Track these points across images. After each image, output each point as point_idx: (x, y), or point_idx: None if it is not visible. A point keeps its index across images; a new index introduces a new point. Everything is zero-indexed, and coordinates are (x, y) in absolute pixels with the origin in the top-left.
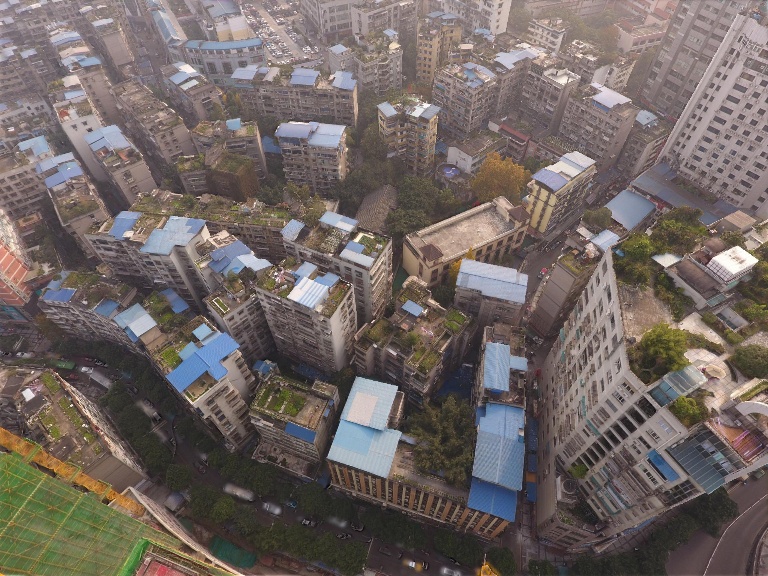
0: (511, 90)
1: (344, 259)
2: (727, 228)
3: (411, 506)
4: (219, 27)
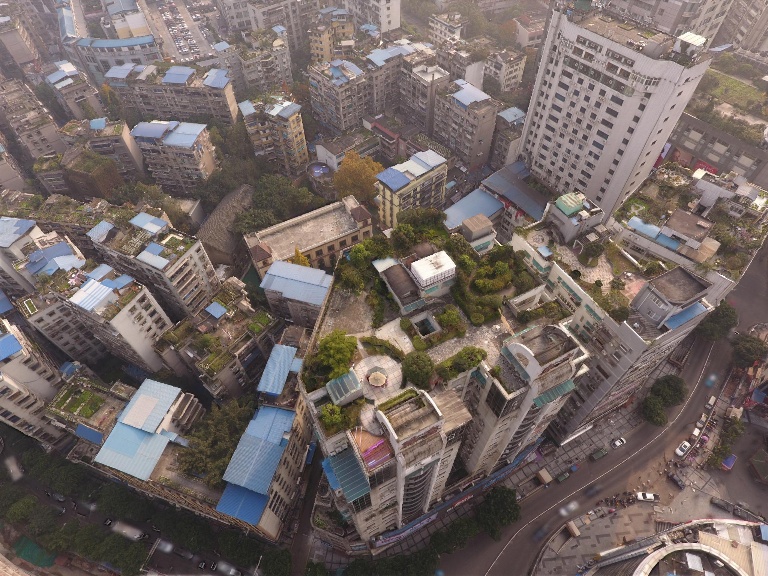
0: (391, 87)
1: (142, 261)
2: (466, 231)
3: None
4: (118, 24)
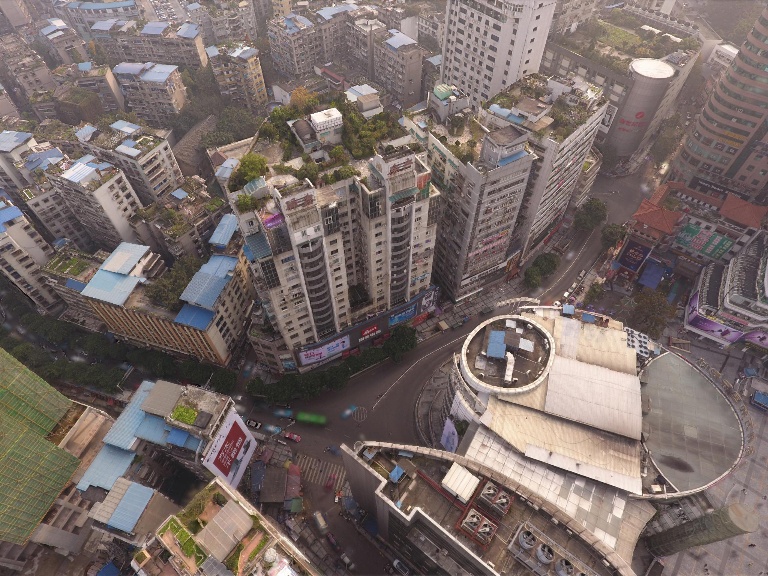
0: (339, 41)
1: (119, 152)
2: (360, 105)
3: (161, 341)
4: None
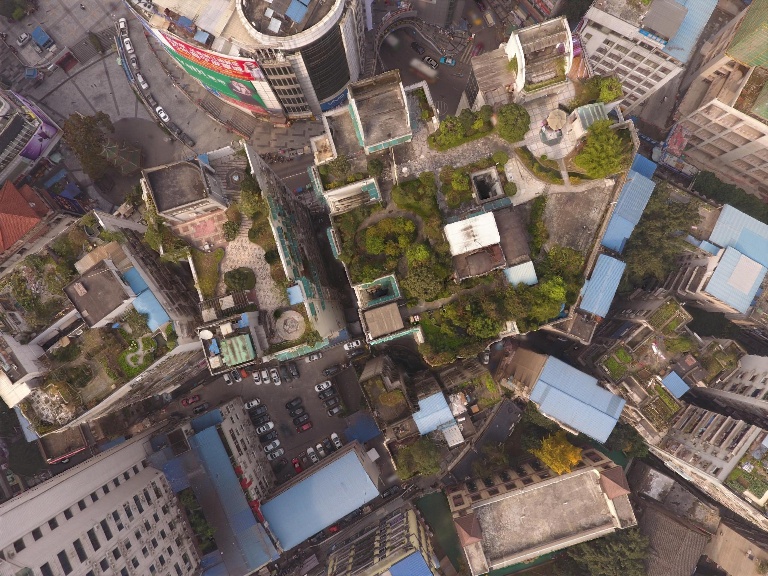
0: None
1: None
2: None
3: None
4: None
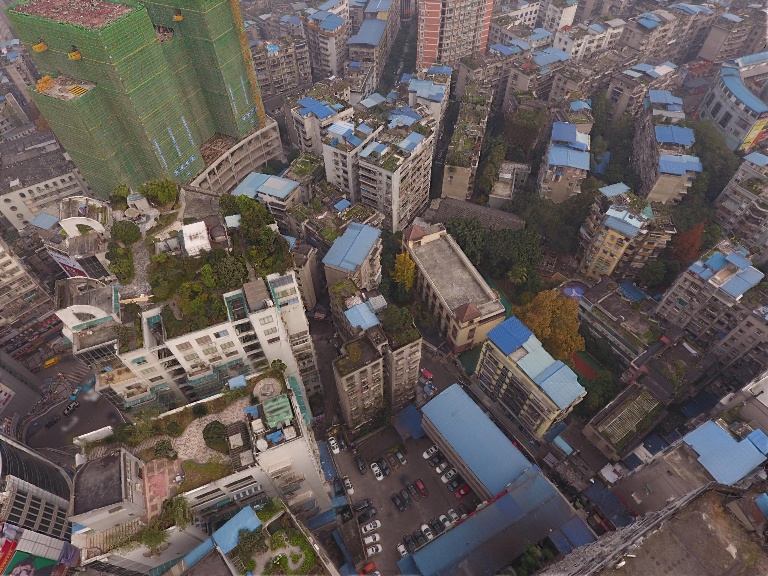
0: None
1: None
2: None
3: None
4: None
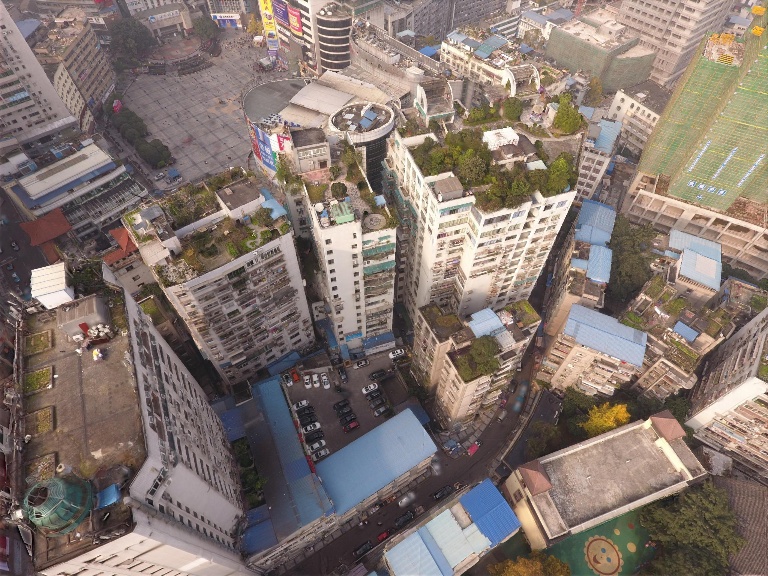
0: None
1: None
2: None
3: None
4: None
